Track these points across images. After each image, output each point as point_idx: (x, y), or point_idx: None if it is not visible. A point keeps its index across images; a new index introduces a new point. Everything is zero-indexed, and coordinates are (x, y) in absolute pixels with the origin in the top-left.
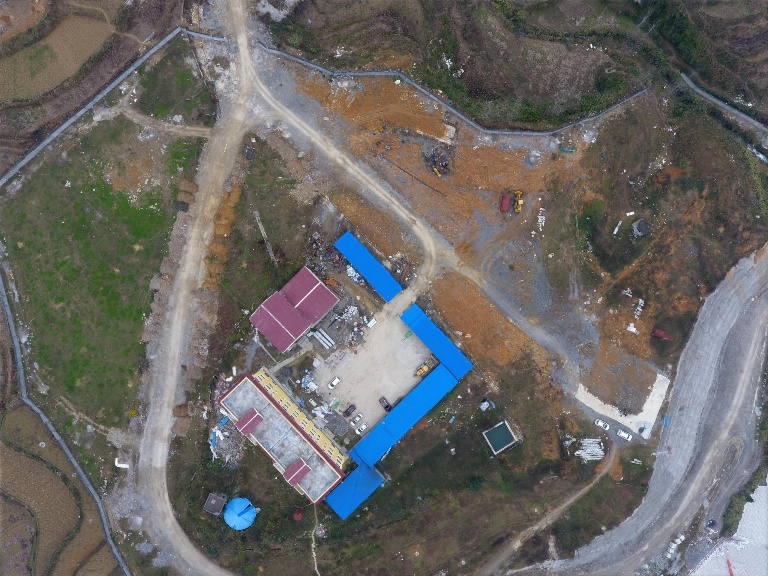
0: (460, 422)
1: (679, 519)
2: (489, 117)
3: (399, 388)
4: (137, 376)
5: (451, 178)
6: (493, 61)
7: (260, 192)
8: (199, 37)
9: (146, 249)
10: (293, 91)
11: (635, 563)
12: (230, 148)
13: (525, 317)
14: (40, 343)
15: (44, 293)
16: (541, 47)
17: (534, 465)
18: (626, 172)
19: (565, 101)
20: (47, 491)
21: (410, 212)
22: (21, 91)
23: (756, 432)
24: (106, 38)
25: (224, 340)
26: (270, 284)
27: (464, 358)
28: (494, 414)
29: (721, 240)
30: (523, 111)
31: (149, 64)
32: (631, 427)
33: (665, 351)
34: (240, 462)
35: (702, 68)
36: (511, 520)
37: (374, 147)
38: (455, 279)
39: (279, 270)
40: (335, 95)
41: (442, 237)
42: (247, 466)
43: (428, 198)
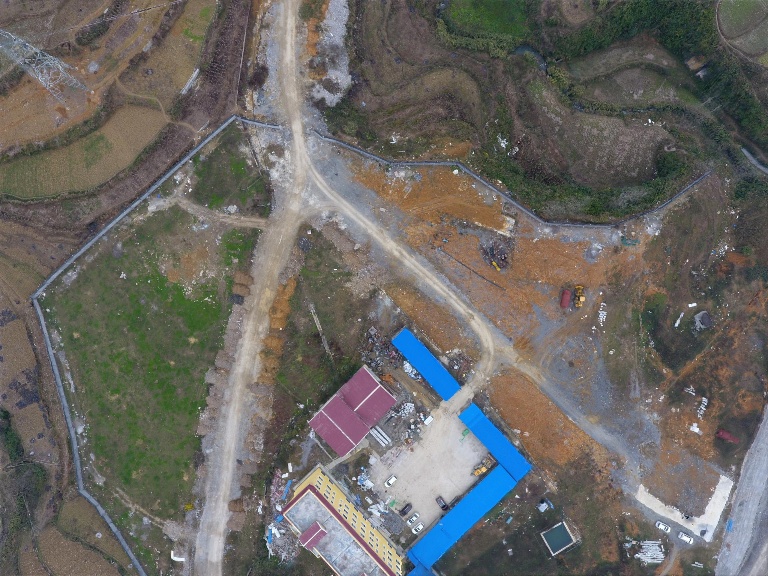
0: (517, 522)
1: None
2: (550, 210)
3: (456, 487)
4: (192, 470)
5: (510, 271)
6: (548, 138)
7: (315, 284)
8: (253, 124)
9: (201, 342)
10: (349, 181)
11: None
12: (285, 240)
13: (585, 415)
14: (96, 434)
15: (100, 384)
16: (598, 122)
17: (592, 567)
18: (689, 262)
19: (631, 197)
20: None
21: (468, 306)
22: (77, 183)
23: None
24: (161, 128)
25: (279, 434)
26: (325, 378)
27: (523, 459)
28: (552, 514)
29: None
30: (585, 202)
31: (204, 153)
32: (692, 529)
33: (729, 452)
34: (296, 559)
35: (766, 145)
36: None
37: (431, 239)
38: (513, 376)
39: (334, 364)
40: (392, 185)
41: (500, 332)
42: (303, 563)
43: (486, 292)
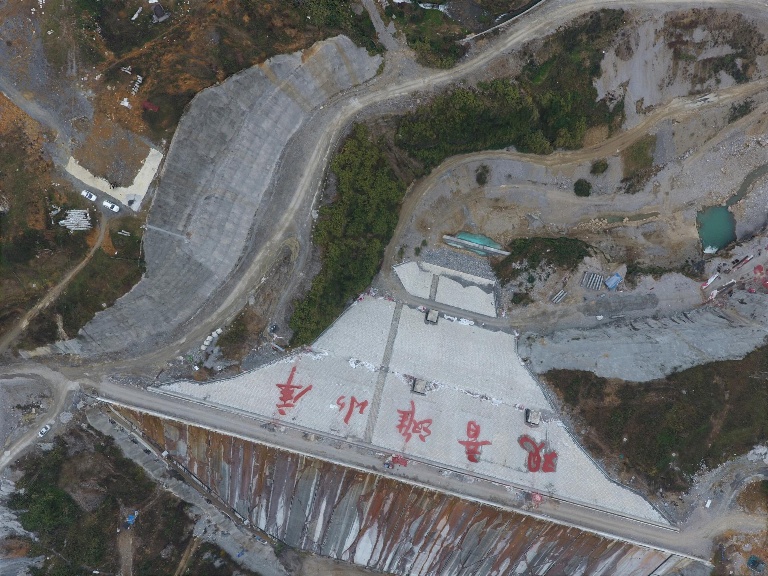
0: None
1: (221, 315)
2: None
3: None
4: None
5: None
6: None
7: None
8: None
9: None
10: None
11: (169, 354)
12: None
13: (20, 92)
14: None
15: None
16: None
17: (19, 235)
18: None
19: None
20: None
21: None
22: None
23: (311, 234)
24: None
25: None
26: None
27: None
28: None
29: (249, 30)
30: None
31: None
32: (120, 199)
33: (156, 124)
34: None
35: None
36: (9, 295)
37: None
38: None
39: None
40: None
41: None
42: None
43: None
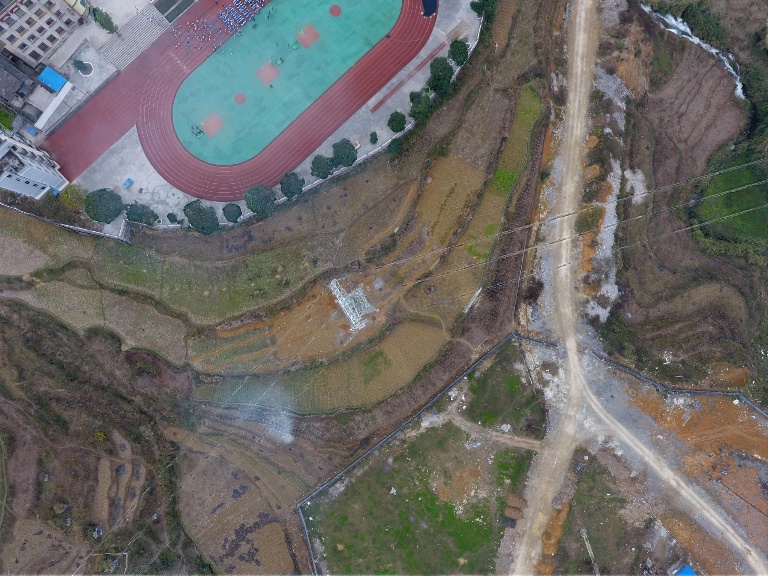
0: None
1: None
2: None
3: None
4: None
5: None
6: None
7: (588, 509)
8: (527, 340)
9: (471, 563)
10: (625, 404)
11: None
12: (560, 463)
13: None
14: None
15: None
16: None
17: None
18: None
19: None
20: None
21: (745, 541)
22: (355, 398)
23: None
24: (441, 346)
25: None
26: None
27: None
28: None
29: None
30: None
31: (479, 370)
32: None
33: None
34: None
35: None
36: None
37: (710, 470)
38: None
39: None
40: (670, 412)
41: None
42: None
43: (764, 527)
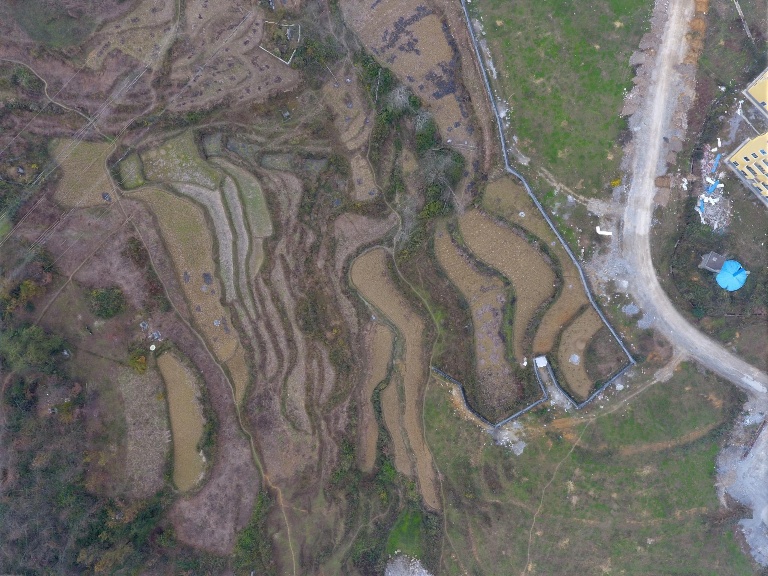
0: None
1: None
2: None
3: None
4: (618, 148)
5: None
6: None
7: None
8: None
9: (626, 26)
10: None
11: None
12: None
13: None
14: (521, 117)
15: (524, 69)
16: None
17: None
18: None
19: None
20: (522, 260)
21: None
22: None
23: None
24: None
25: (702, 115)
26: (747, 62)
27: None
28: None
29: None
30: None
31: None
32: None
33: None
34: (728, 228)
35: None
36: None
37: None
38: None
39: (756, 48)
40: None
41: None
42: (734, 232)
43: None
